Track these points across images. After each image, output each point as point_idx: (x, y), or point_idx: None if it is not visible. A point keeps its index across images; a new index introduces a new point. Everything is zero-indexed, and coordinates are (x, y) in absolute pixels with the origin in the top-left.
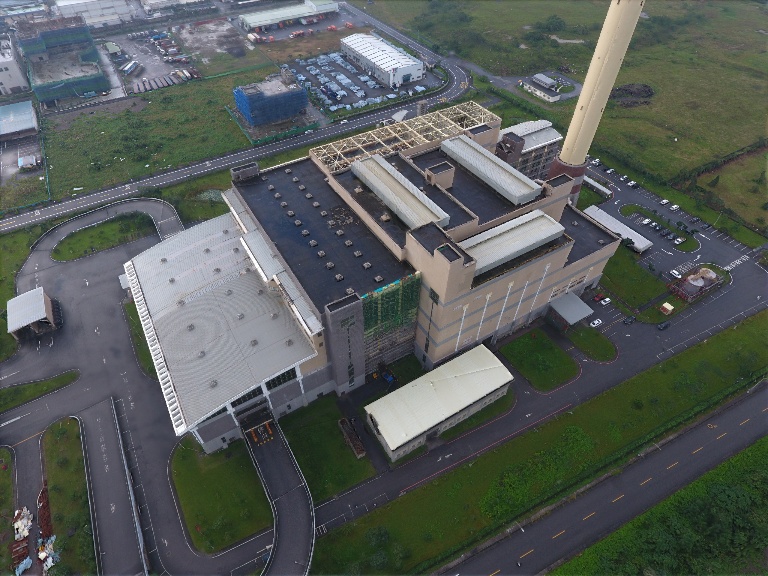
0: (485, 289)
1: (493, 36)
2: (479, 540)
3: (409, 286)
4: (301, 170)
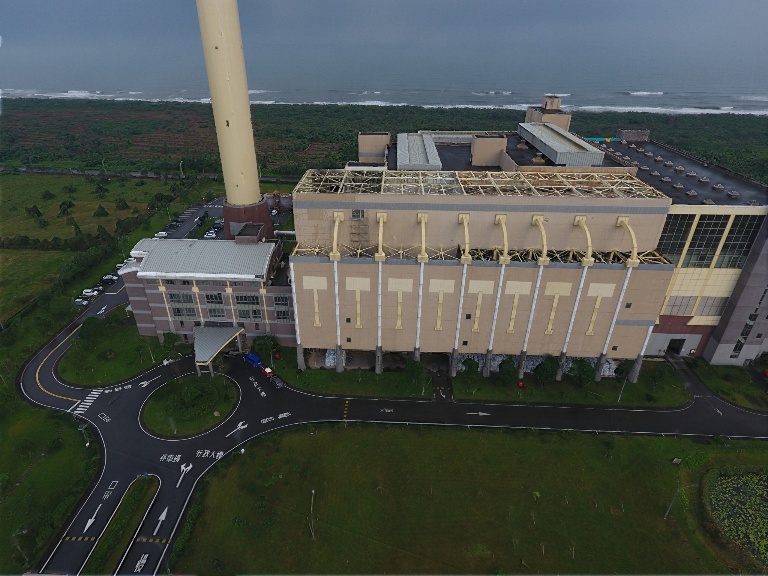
0: None
1: None
2: None
3: None
4: (684, 202)
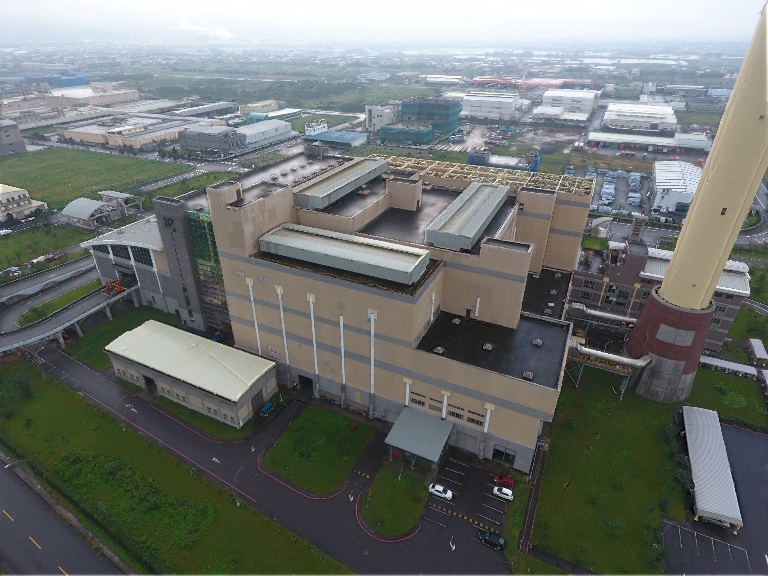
0: (271, 273)
1: None
2: None
3: None
4: None
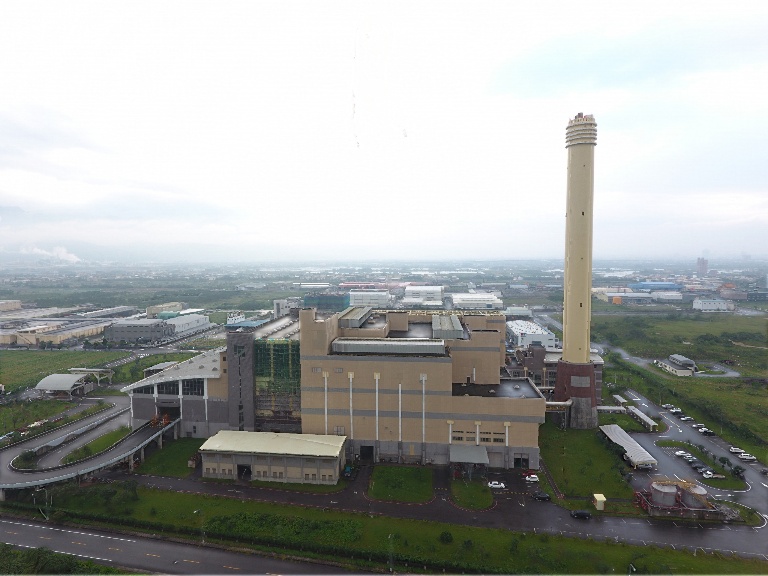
0: (345, 364)
1: (660, 335)
2: (177, 533)
3: (296, 347)
4: None
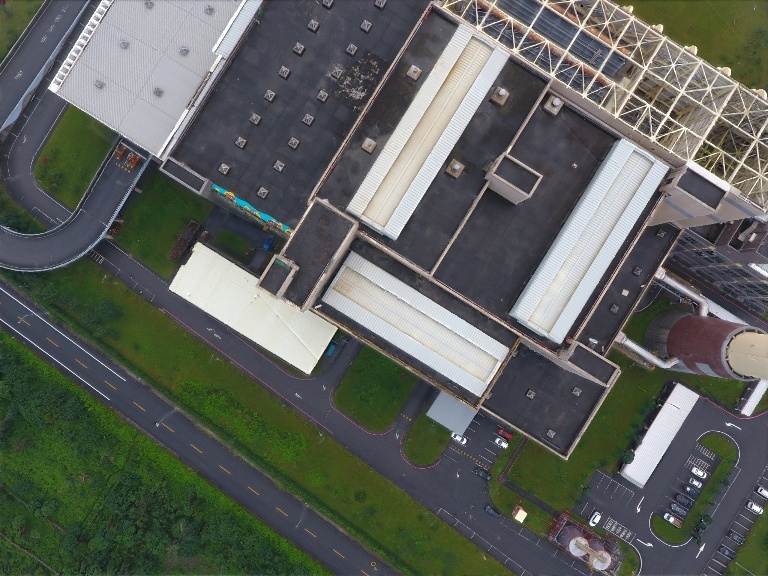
0: None
1: None
2: None
3: None
4: None
